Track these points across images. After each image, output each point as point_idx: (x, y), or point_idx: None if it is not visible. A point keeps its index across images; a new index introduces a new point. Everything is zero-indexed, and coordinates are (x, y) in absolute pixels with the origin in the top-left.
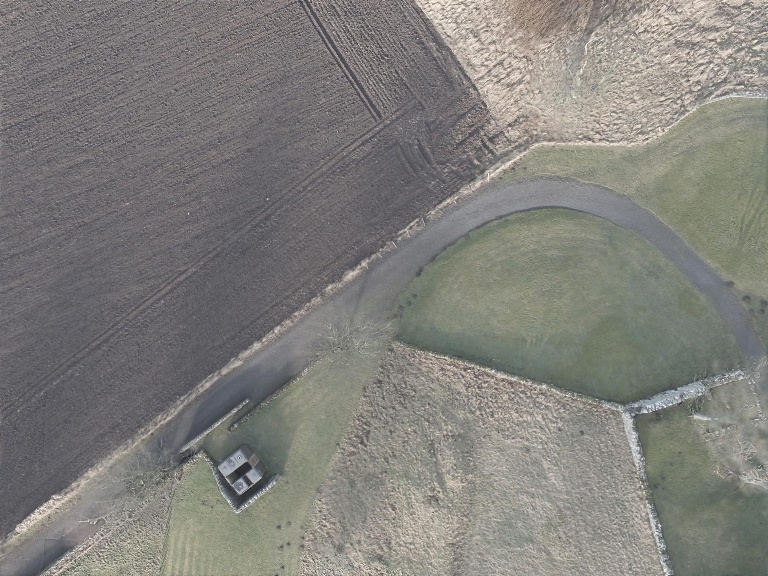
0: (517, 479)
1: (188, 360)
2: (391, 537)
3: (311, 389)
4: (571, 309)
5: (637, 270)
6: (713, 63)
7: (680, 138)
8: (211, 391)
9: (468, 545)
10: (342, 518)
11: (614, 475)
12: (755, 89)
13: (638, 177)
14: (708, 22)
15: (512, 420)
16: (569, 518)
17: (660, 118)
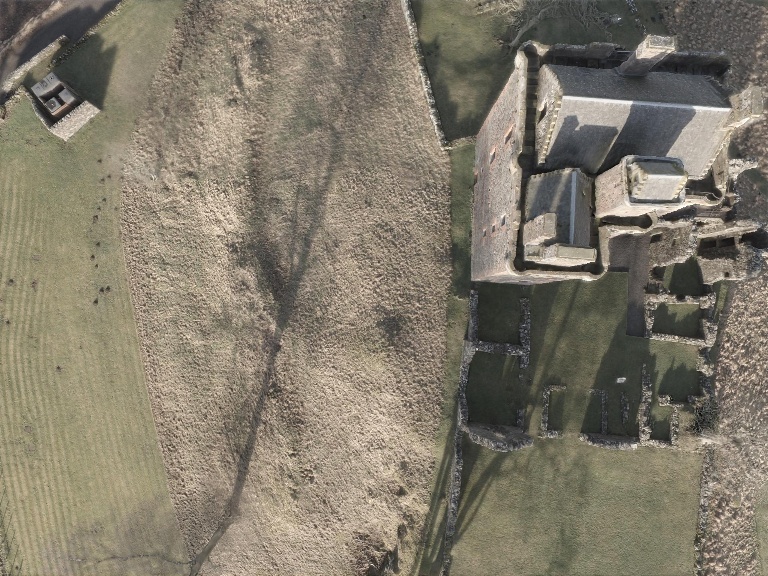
0: (309, 73)
1: (11, 7)
2: (200, 152)
3: (126, 24)
4: None
5: None
6: None
7: None
8: (33, 35)
9: (267, 144)
10: (158, 147)
11: (392, 49)
12: None
13: None
14: None
15: (304, 20)
16: (350, 92)
17: None
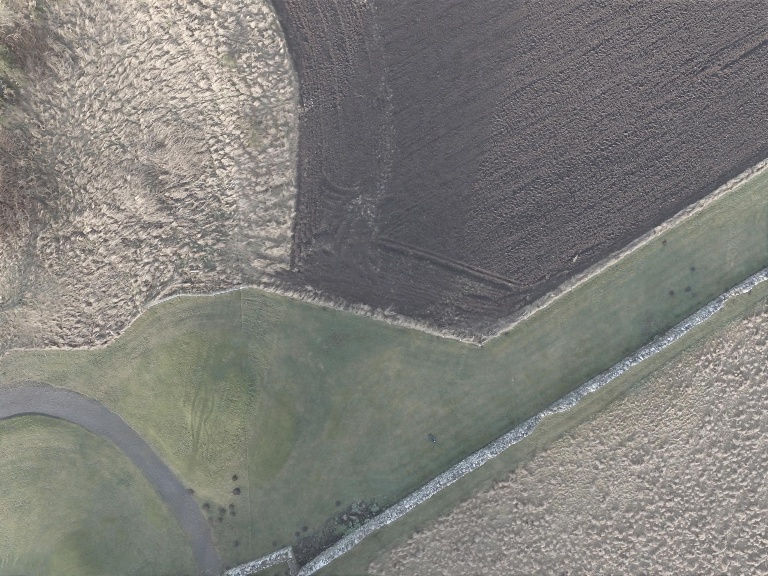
0: None
1: None
2: None
3: None
4: (37, 527)
5: (106, 479)
6: (157, 262)
7: (136, 340)
8: None
9: None
10: None
11: None
12: (202, 286)
13: (105, 380)
14: (151, 218)
15: None
16: None
17: (116, 320)
